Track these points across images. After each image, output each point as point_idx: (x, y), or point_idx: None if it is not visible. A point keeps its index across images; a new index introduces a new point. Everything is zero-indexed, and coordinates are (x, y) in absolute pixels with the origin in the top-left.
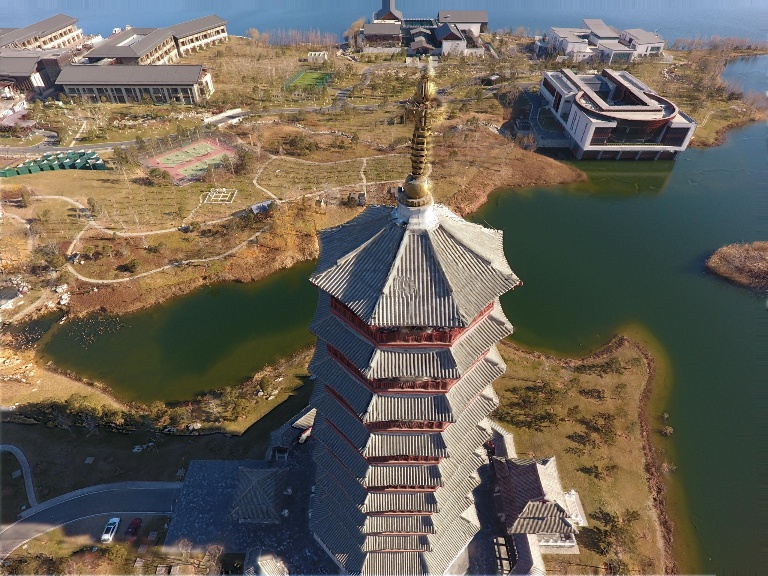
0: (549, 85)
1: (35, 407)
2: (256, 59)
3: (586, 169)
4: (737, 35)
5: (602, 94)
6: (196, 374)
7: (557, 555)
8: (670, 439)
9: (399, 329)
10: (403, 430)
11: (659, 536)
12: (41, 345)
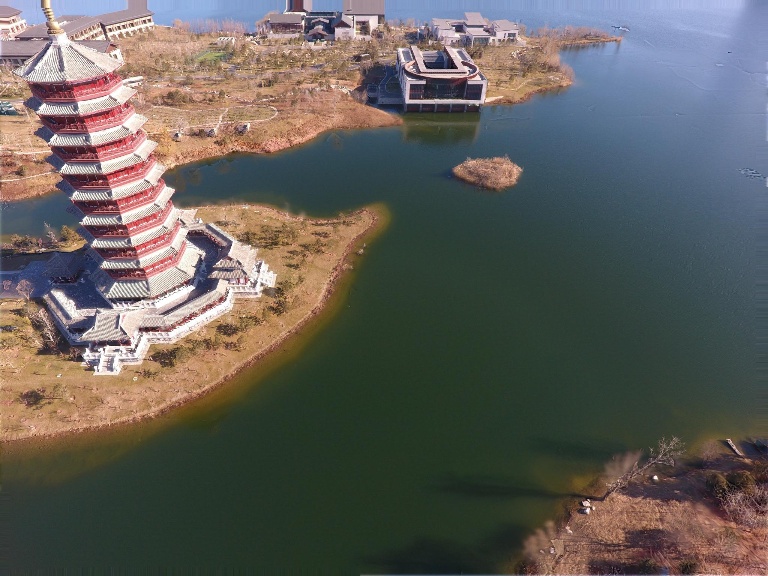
0: (398, 58)
1: None
2: (173, 43)
3: (407, 118)
4: (587, 25)
5: (439, 65)
6: (55, 231)
7: (246, 298)
8: (362, 257)
9: None
10: (80, 160)
11: (321, 295)
12: None
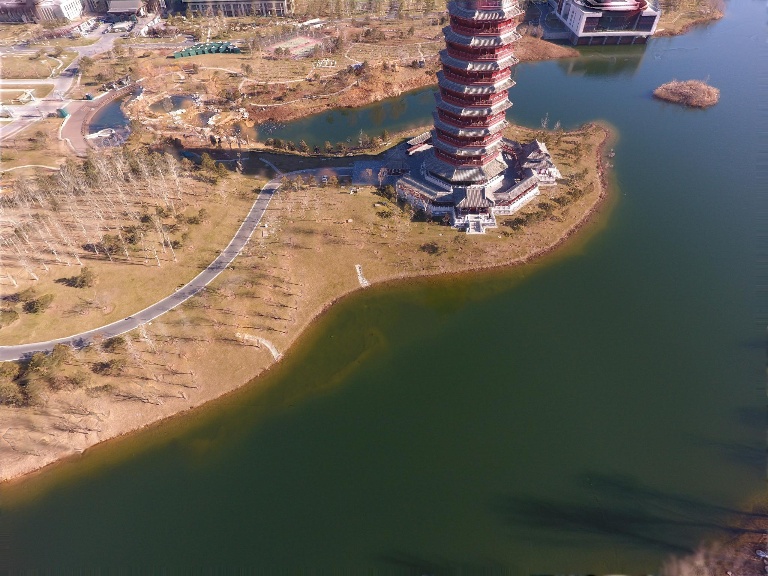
0: None
1: (259, 149)
2: None
3: (580, 50)
4: None
5: (596, 0)
6: None
7: (546, 186)
8: (613, 160)
9: (485, 2)
10: (482, 59)
11: (600, 186)
12: (243, 133)
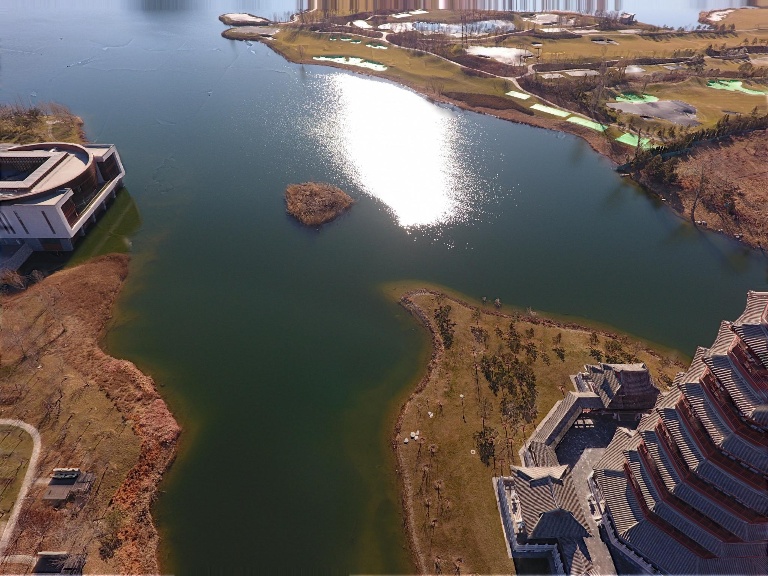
0: None
1: None
2: None
3: (100, 251)
4: None
5: None
6: None
7: None
8: None
9: None
10: None
11: None
12: None
